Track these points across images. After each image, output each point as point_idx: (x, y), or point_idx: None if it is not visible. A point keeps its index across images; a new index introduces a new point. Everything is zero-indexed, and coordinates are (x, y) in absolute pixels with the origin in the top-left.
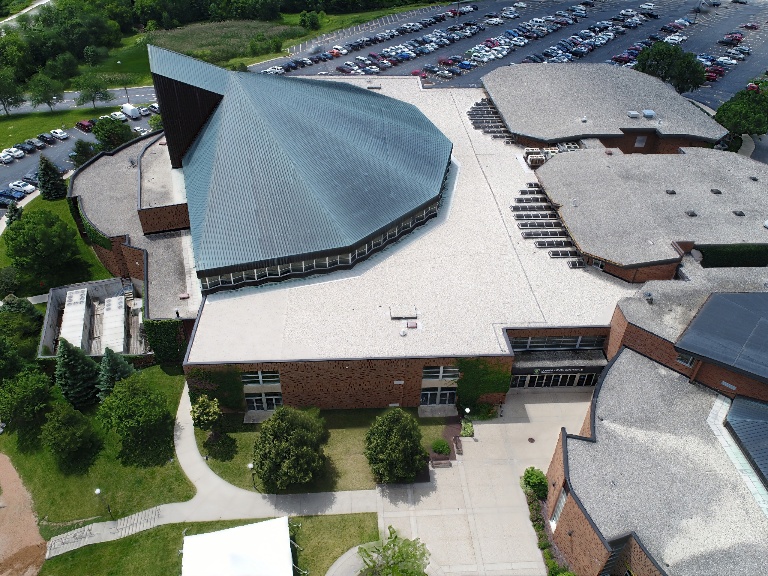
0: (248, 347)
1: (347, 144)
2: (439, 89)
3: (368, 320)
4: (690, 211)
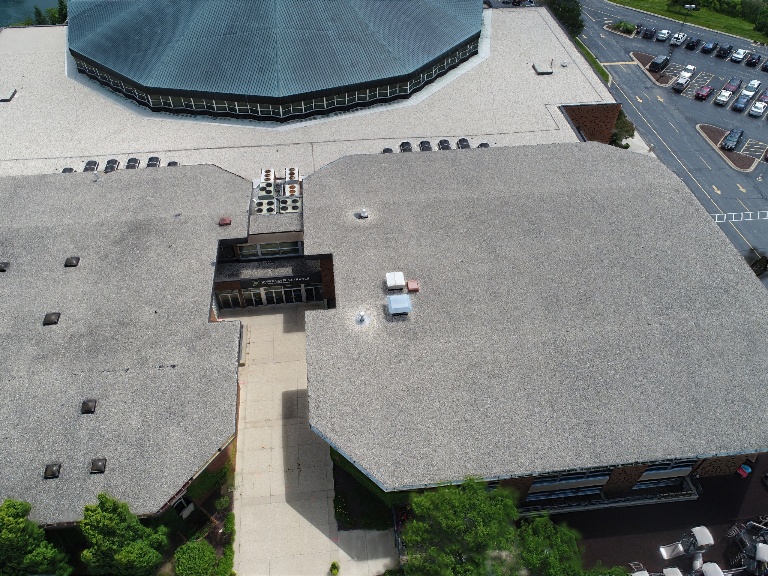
0: (6, 44)
1: (198, 7)
2: (562, 119)
3: (6, 82)
4: (7, 267)
